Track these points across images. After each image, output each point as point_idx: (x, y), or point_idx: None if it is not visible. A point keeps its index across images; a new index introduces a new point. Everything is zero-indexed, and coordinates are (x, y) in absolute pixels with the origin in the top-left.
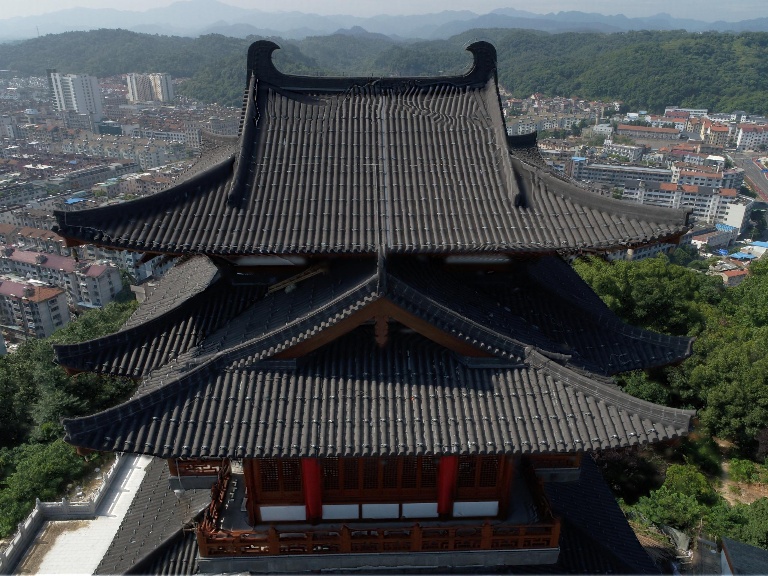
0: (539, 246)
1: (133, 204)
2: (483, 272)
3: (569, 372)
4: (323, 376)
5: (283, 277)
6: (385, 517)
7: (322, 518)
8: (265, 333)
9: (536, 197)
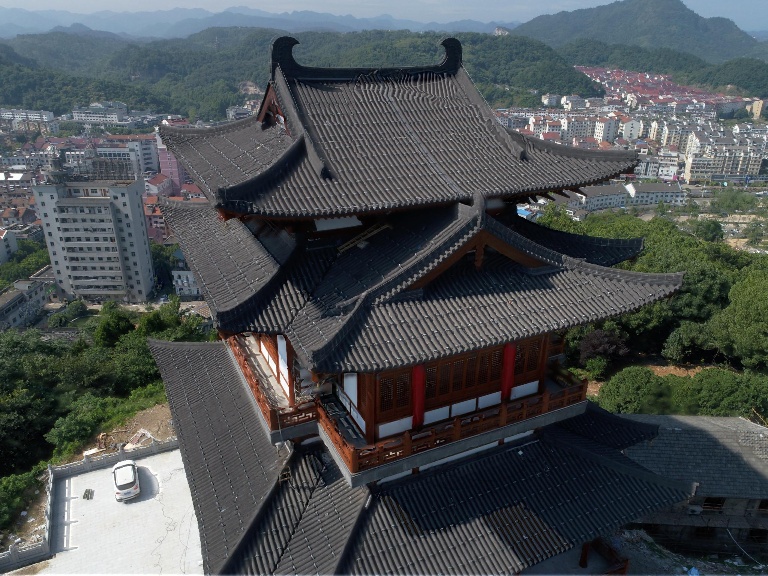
0: (540, 187)
1: (256, 180)
2: (493, 215)
3: (597, 266)
4: (443, 298)
5: (348, 238)
6: (466, 412)
7: (423, 424)
8: (383, 275)
9: (529, 153)
